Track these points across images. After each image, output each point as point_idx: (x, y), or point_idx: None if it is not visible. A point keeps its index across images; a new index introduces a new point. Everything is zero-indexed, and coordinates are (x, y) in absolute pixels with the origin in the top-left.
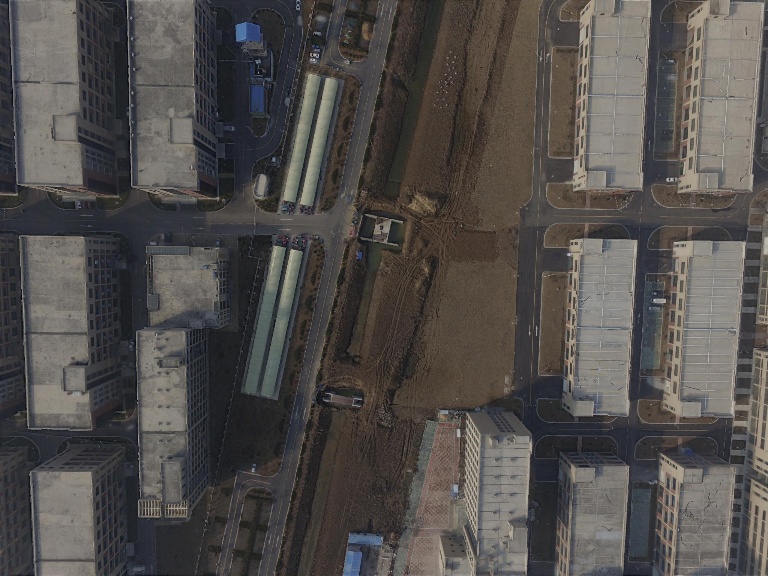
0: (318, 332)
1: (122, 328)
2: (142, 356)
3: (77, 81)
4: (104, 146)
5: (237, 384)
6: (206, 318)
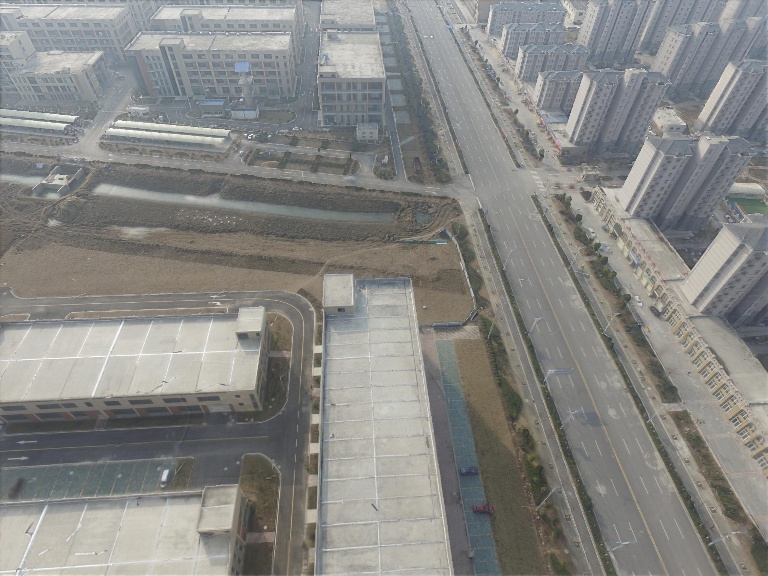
0: None
1: None
2: (4, 33)
3: None
4: None
5: None
6: (23, 70)
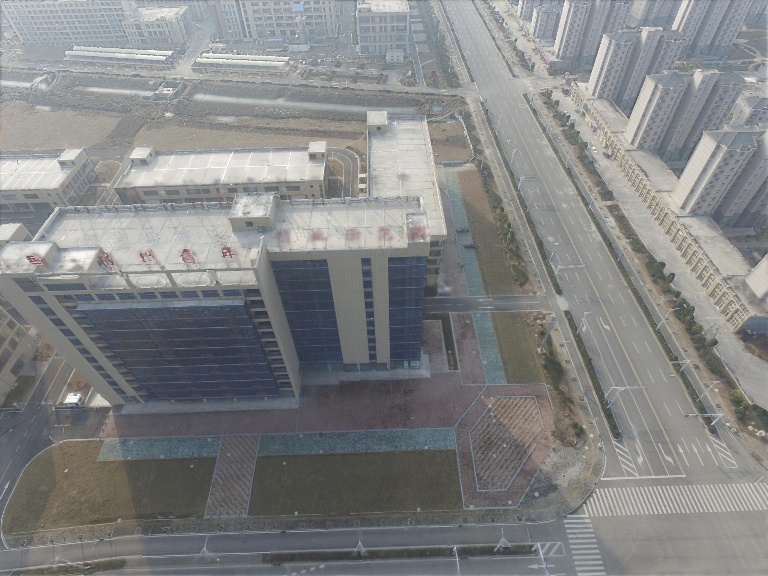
0: None
1: None
2: None
3: None
4: None
5: None
6: (131, 19)
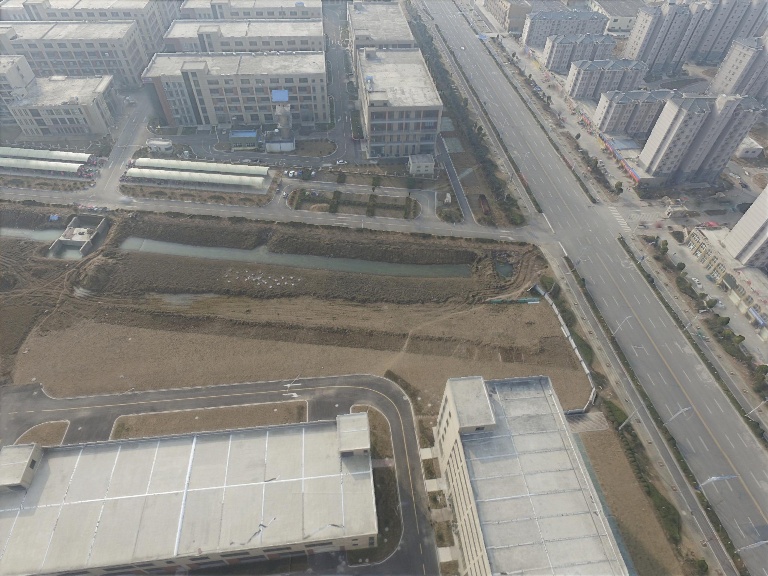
0: None
1: None
2: None
3: None
4: None
5: None
6: (24, 101)
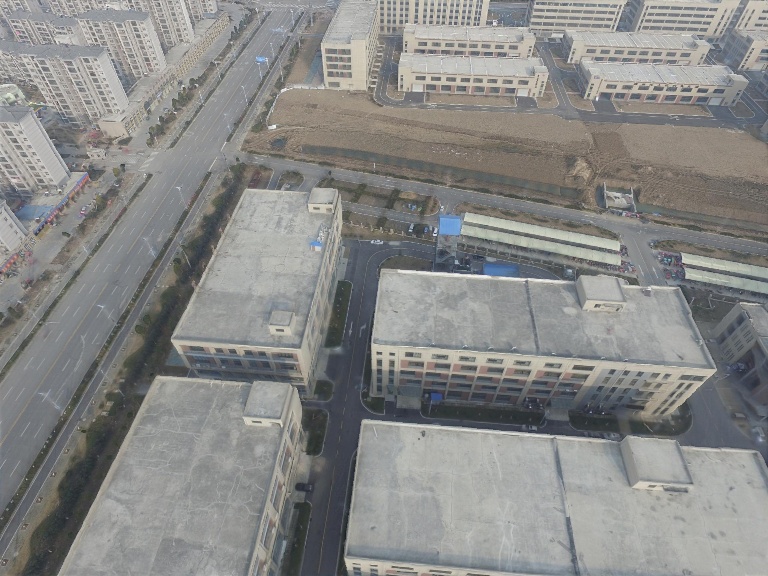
0: None
1: None
2: None
3: (550, 443)
4: None
5: None
6: None
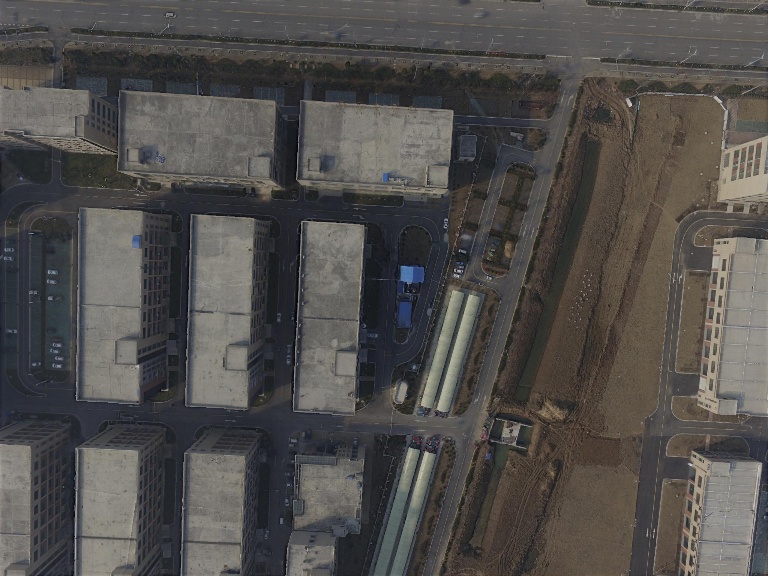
0: (444, 527)
1: (258, 517)
2: (291, 567)
3: (248, 312)
4: (258, 356)
5: (364, 573)
6: (348, 524)
